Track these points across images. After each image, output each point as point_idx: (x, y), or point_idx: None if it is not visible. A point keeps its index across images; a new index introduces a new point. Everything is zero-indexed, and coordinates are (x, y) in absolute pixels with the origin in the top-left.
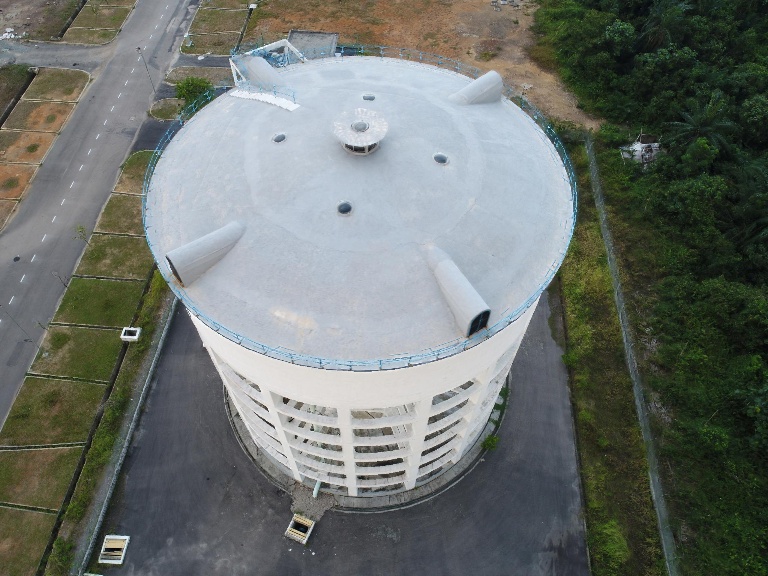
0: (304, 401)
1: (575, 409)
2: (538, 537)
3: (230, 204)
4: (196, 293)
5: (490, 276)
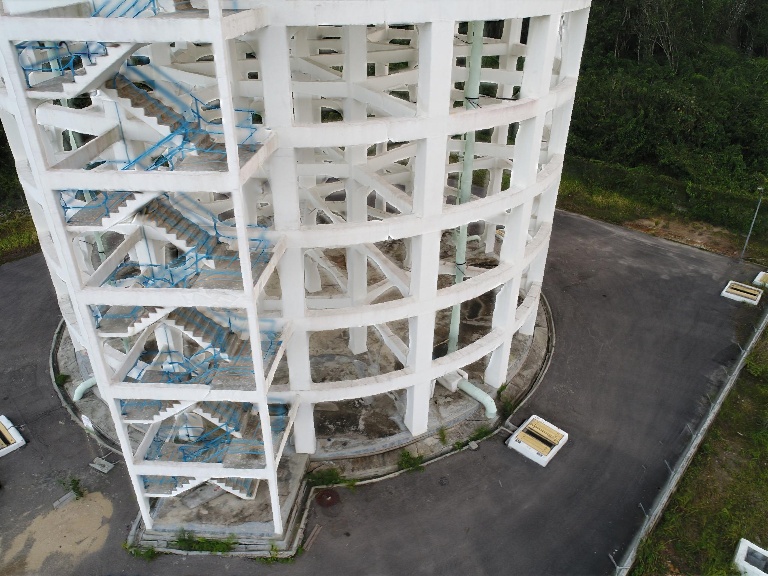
0: None
1: None
2: None
3: None
4: None
5: None
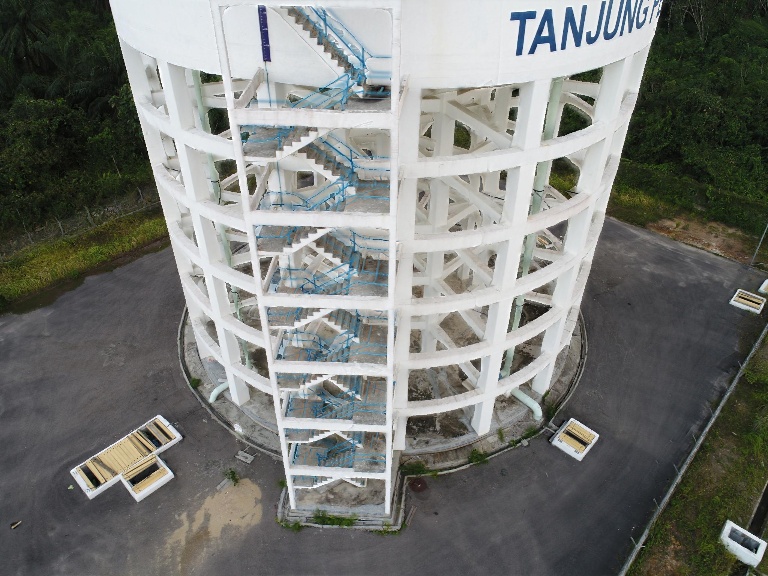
0: None
1: None
2: None
3: None
4: None
5: None
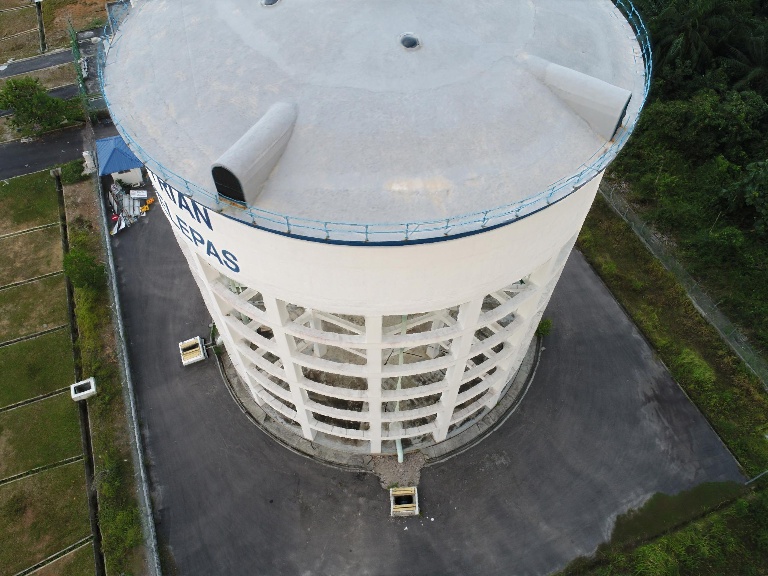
0: (432, 308)
1: (595, 267)
2: (632, 395)
3: (256, 87)
4: (269, 207)
5: (593, 73)
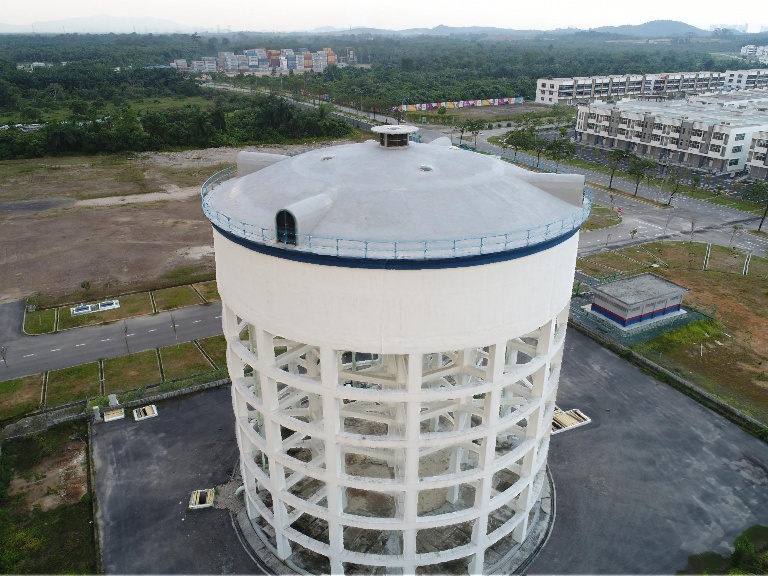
0: None
1: None
2: None
3: None
4: None
5: (344, 225)
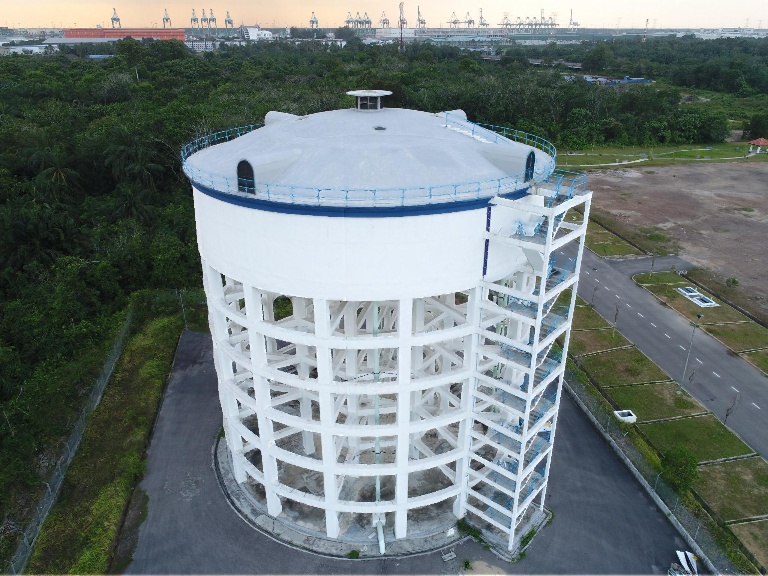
0: None
1: (148, 438)
2: (210, 365)
3: None
4: None
5: None
